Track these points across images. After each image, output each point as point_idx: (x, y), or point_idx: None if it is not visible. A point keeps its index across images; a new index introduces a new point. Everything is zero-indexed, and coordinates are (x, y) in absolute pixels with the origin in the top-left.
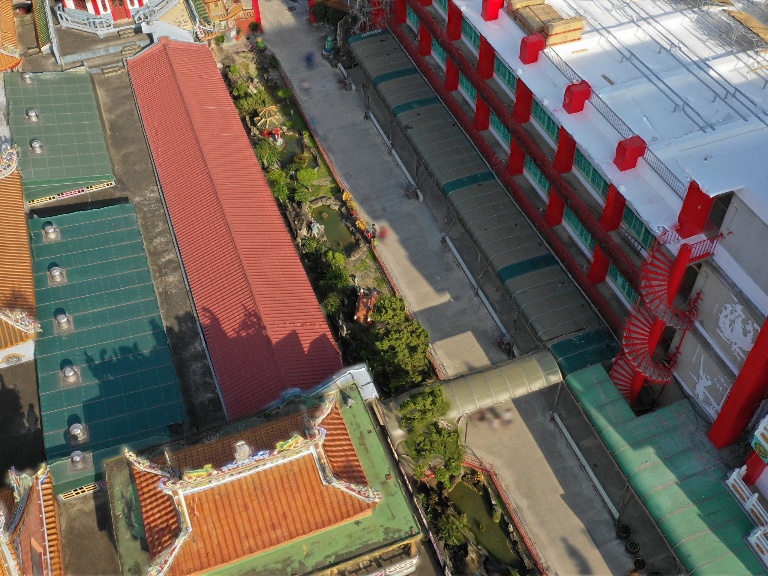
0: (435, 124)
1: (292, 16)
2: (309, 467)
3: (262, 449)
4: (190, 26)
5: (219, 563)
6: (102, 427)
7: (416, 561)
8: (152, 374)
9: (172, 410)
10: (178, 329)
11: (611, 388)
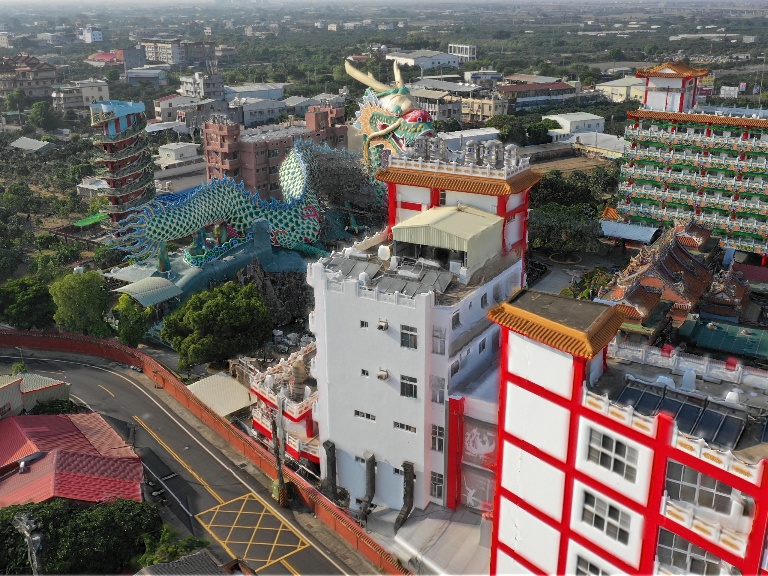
0: None
1: None
2: None
3: (640, 302)
4: None
5: None
6: (711, 331)
7: None
8: (729, 346)
9: (705, 344)
10: (759, 367)
11: None
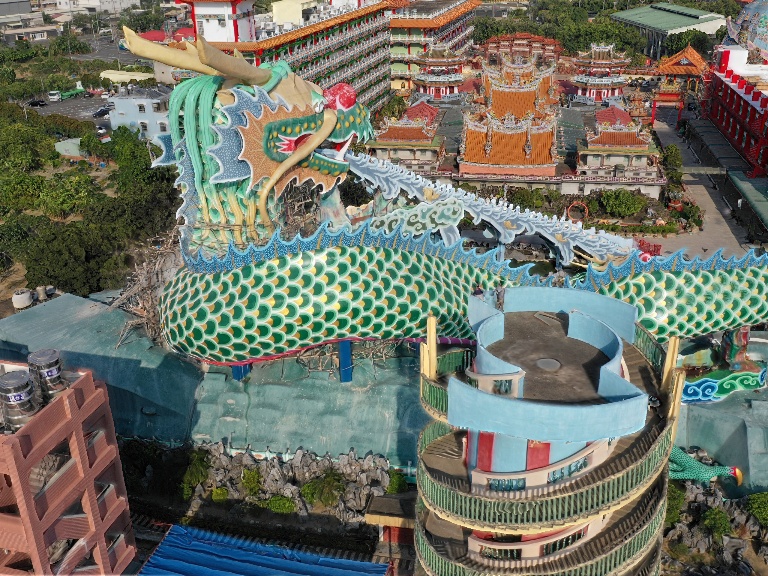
0: (714, 135)
1: (669, 127)
2: (634, 134)
3: None
4: (624, 107)
5: (604, 144)
6: None
7: (657, 177)
8: None
9: None
10: None
11: (742, 174)
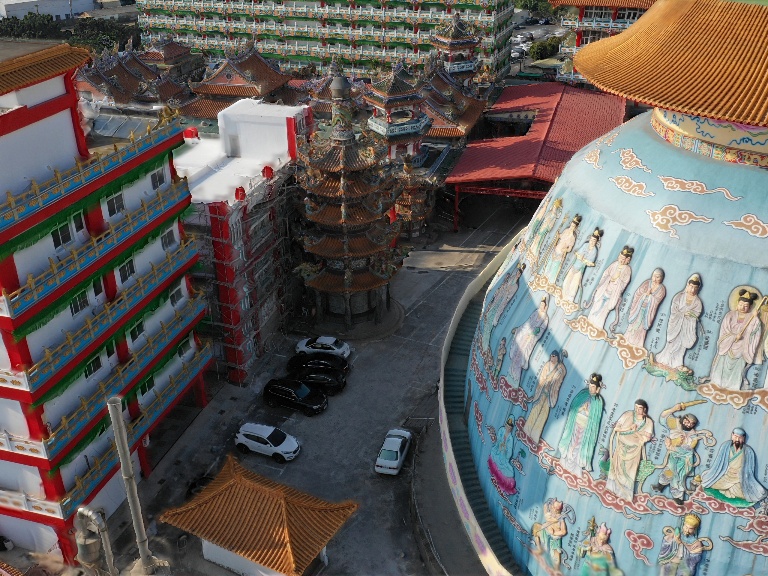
0: None
1: None
2: None
3: None
4: None
5: None
6: None
7: None
8: None
9: None
10: None
11: None
